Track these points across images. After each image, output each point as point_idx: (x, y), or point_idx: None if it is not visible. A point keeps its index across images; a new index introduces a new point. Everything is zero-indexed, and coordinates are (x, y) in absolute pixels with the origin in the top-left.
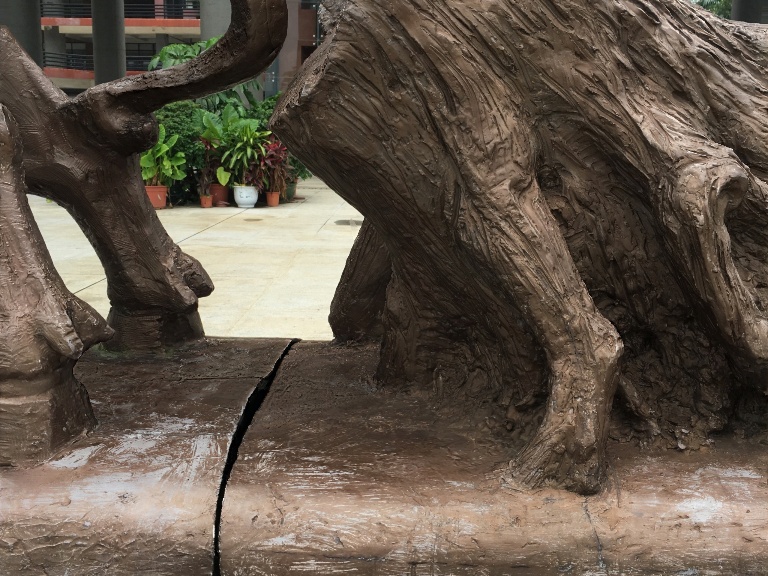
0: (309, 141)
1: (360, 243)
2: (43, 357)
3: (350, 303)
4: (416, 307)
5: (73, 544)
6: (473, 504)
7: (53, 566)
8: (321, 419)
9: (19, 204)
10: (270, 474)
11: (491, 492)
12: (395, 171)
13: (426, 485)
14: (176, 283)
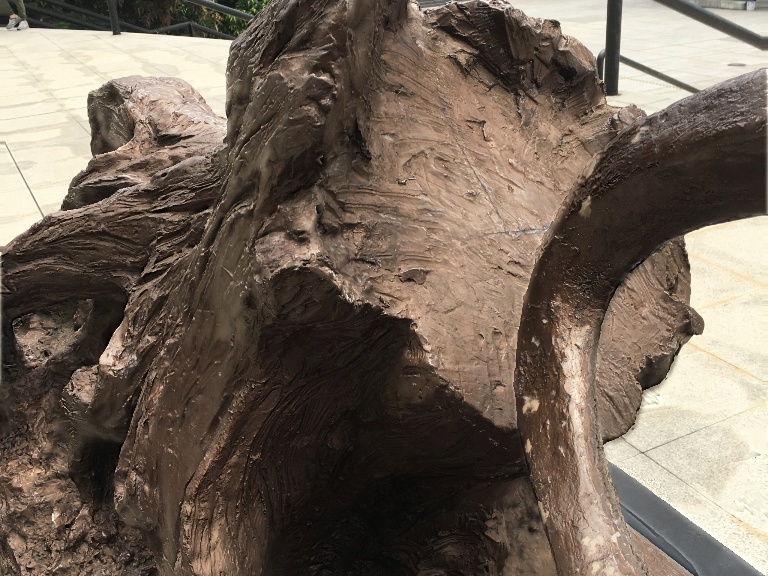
0: None
1: None
2: None
3: None
4: None
5: None
6: (632, 531)
7: None
8: None
9: None
10: None
11: None
12: None
13: None
14: None
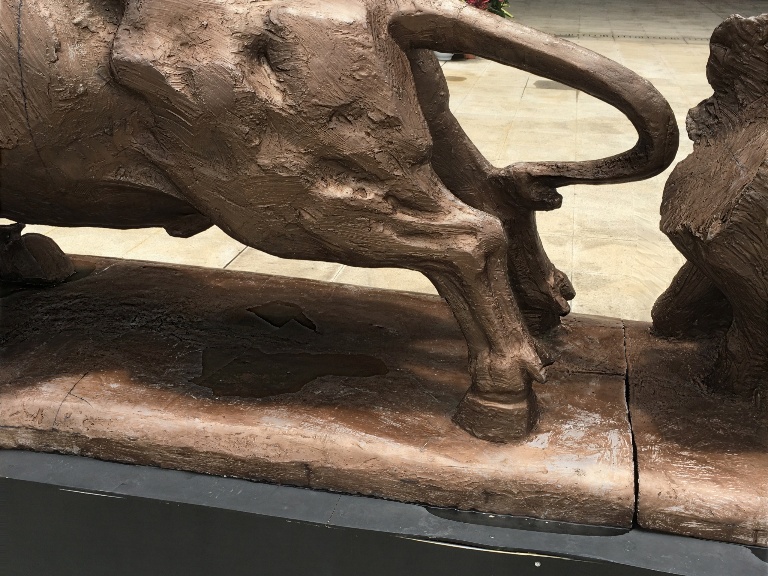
0: (702, 259)
1: (688, 272)
2: (524, 381)
3: (675, 312)
4: (750, 352)
5: (551, 497)
6: None
7: (539, 507)
8: (677, 418)
9: (507, 283)
10: (662, 464)
11: None
12: (761, 285)
13: (763, 482)
14: (556, 296)
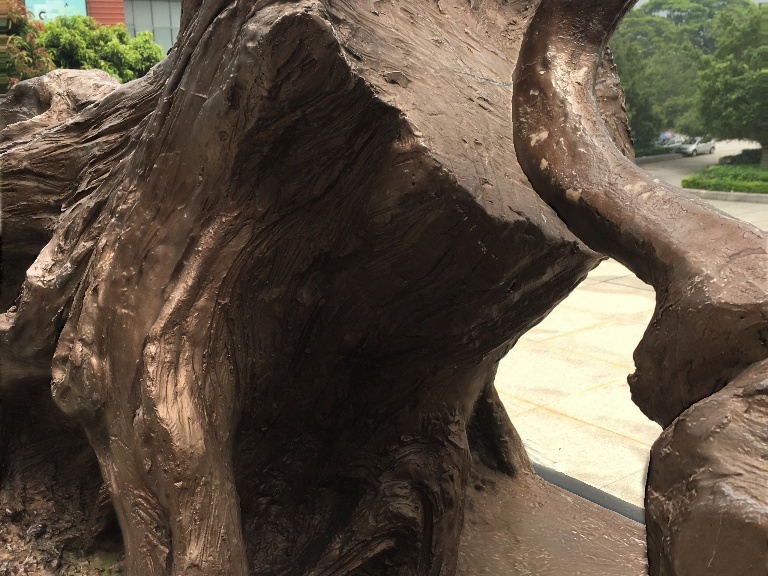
0: None
1: (231, 534)
2: None
3: None
4: None
5: None
6: (574, 494)
7: None
8: None
9: None
10: None
11: (555, 487)
12: None
13: None
14: None
